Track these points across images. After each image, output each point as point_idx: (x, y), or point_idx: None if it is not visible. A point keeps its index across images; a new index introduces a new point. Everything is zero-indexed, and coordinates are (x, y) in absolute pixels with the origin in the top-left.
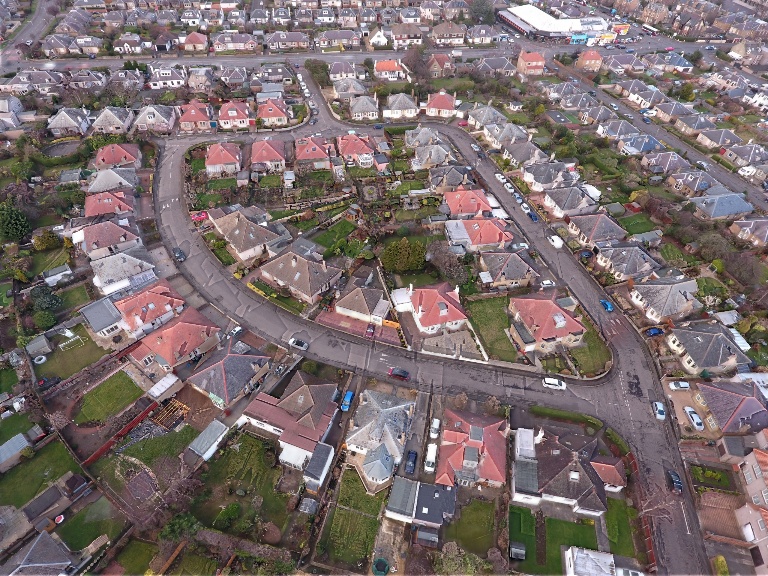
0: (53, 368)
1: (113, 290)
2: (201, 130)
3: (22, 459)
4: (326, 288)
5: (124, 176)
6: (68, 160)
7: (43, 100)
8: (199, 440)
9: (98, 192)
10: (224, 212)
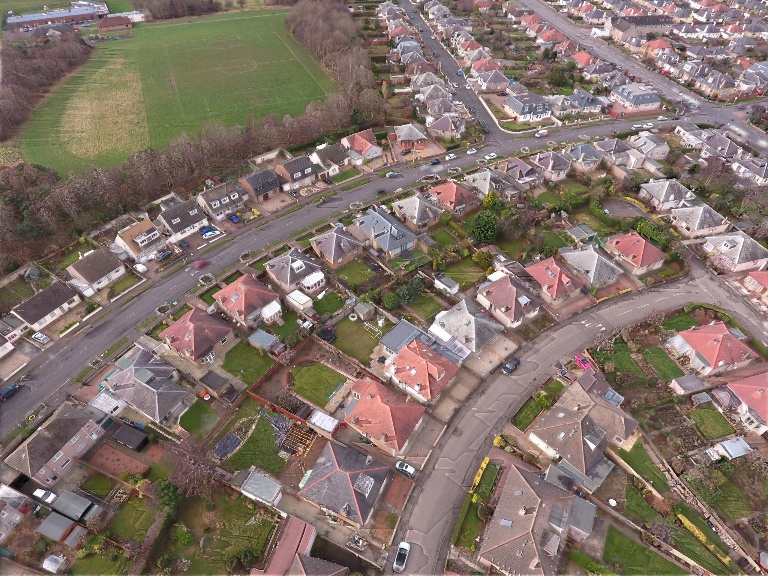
0: (346, 329)
1: (435, 332)
2: (760, 300)
3: (258, 350)
4: (511, 575)
5: (600, 269)
6: (605, 220)
7: (686, 162)
8: (259, 479)
9: (567, 261)
10: (590, 387)
